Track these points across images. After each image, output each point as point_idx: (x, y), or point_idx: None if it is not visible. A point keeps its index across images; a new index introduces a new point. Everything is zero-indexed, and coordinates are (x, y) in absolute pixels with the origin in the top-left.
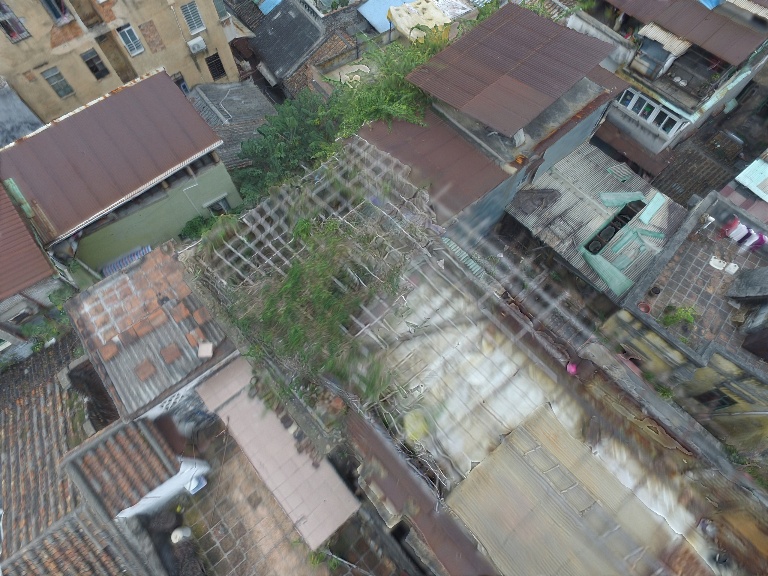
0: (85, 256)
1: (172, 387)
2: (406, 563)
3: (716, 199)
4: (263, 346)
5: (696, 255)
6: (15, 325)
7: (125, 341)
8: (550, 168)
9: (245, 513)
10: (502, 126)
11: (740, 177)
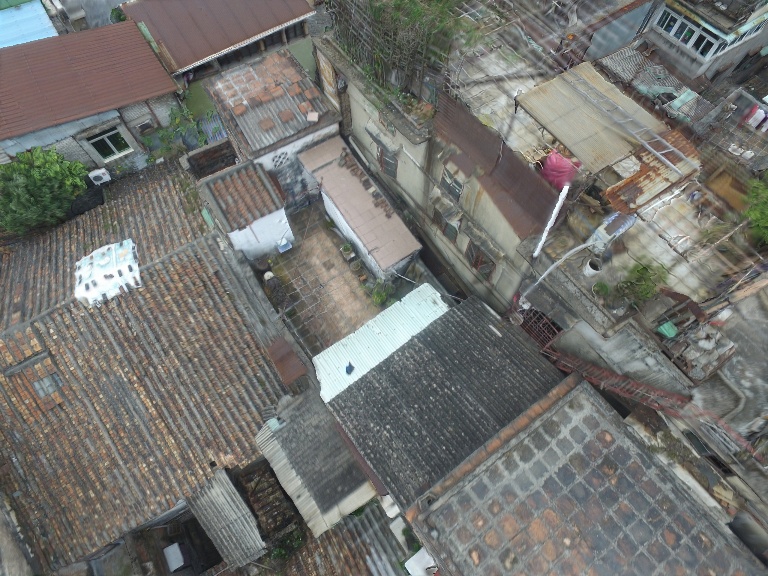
0: (189, 102)
1: (286, 139)
2: (451, 302)
3: (741, 95)
4: (381, 53)
5: (717, 143)
6: (139, 133)
7: (252, 103)
8: (595, 60)
9: (320, 273)
10: None
11: (767, 98)
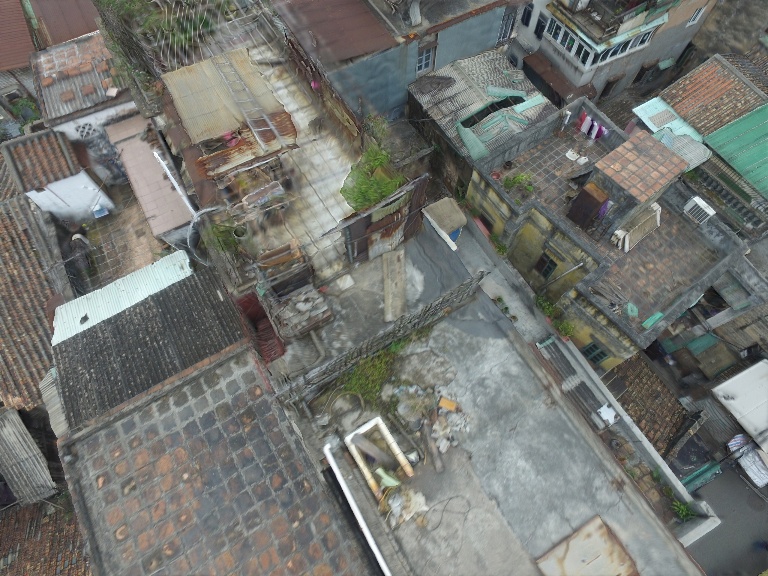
0: None
1: (83, 110)
2: None
3: (583, 103)
4: (114, 33)
5: (557, 147)
6: (8, 102)
7: (59, 76)
8: (453, 61)
9: (130, 239)
10: None
11: (637, 109)
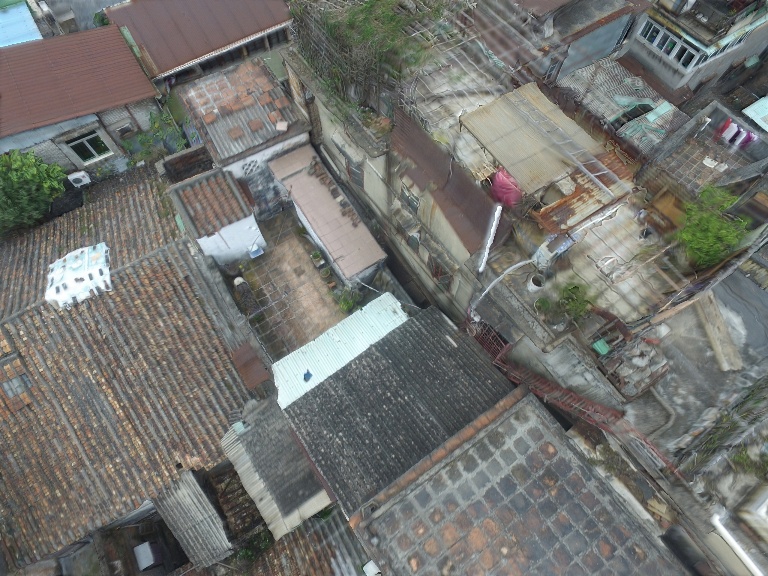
0: (172, 106)
1: (255, 147)
2: (415, 310)
3: (716, 108)
4: (340, 68)
5: (692, 155)
6: (119, 137)
7: (223, 112)
8: (573, 71)
9: (291, 279)
10: (535, 7)
11: (746, 110)
